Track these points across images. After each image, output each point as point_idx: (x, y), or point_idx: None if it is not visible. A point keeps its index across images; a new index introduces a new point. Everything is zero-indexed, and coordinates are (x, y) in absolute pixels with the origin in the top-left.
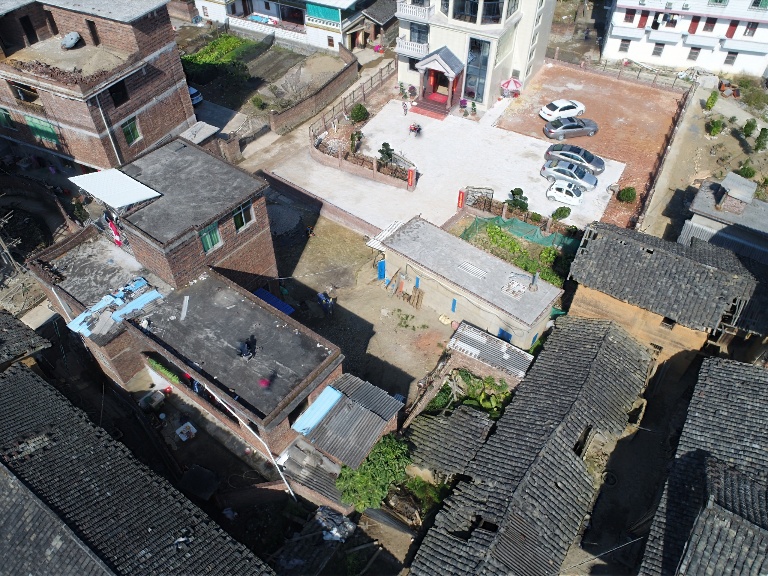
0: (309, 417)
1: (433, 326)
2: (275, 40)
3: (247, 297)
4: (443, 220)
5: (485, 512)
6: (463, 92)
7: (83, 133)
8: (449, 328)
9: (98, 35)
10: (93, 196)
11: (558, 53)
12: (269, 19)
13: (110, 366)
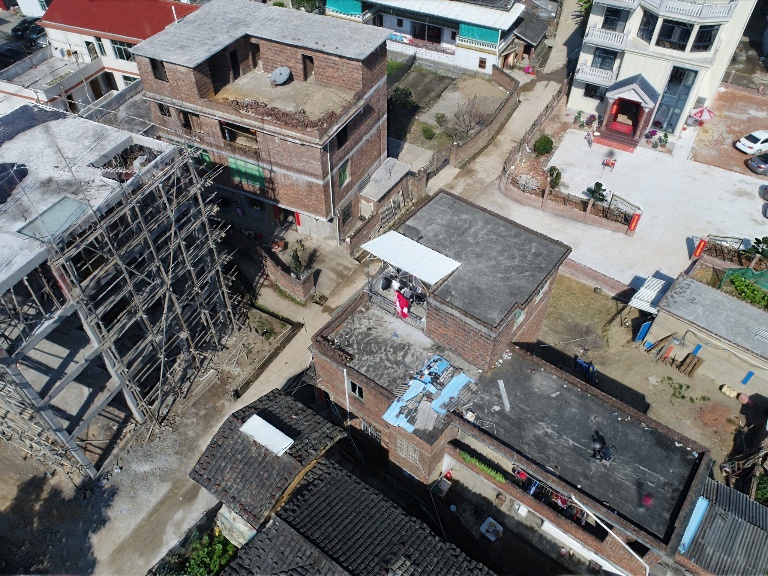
0: None
1: (715, 398)
2: (416, 60)
3: (569, 382)
4: (679, 270)
5: None
6: (651, 122)
7: (302, 178)
8: (735, 401)
9: (307, 70)
10: (392, 267)
11: (733, 77)
12: (403, 37)
13: (418, 460)
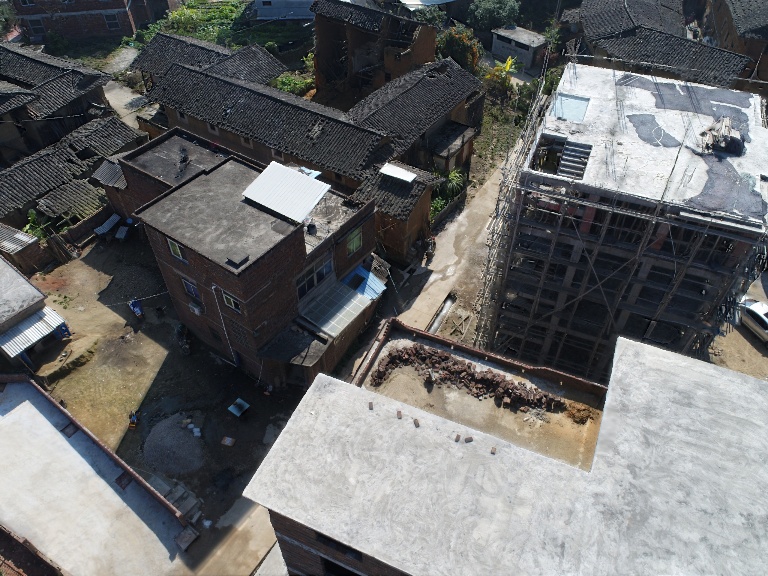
0: None
1: None
2: None
3: None
4: None
5: (72, 154)
6: None
7: None
8: None
9: None
10: None
11: None
12: None
13: None
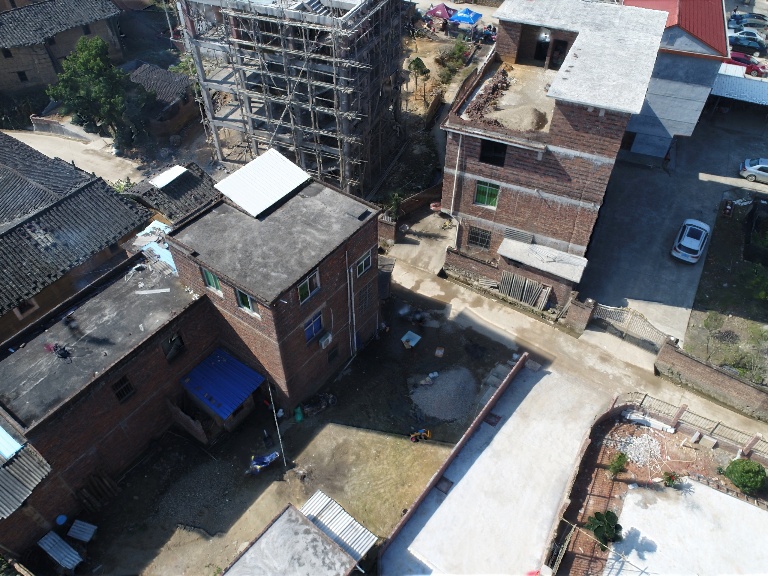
0: None
1: None
2: None
3: None
4: None
5: None
6: None
7: None
8: None
9: None
10: None
11: None
12: None
13: None
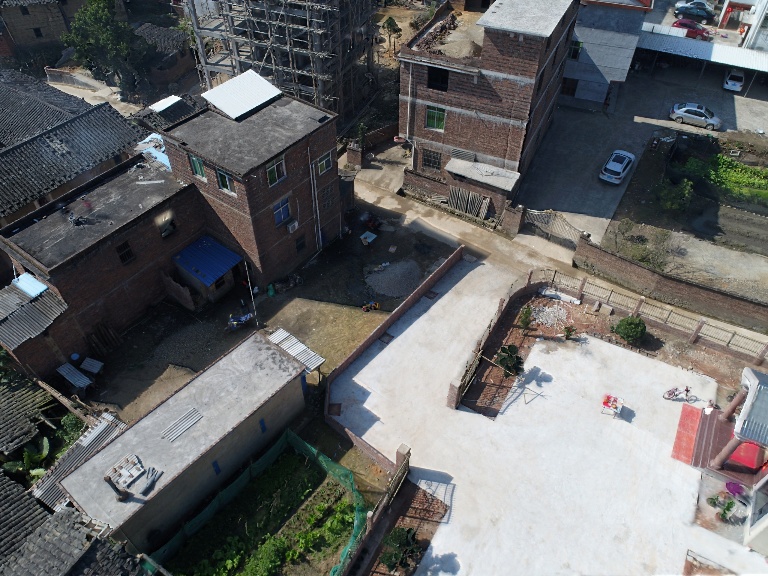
0: (27, 280)
1: None
2: None
3: None
4: (381, 444)
5: None
6: (762, 483)
7: None
8: None
9: None
10: None
11: None
12: None
13: None
